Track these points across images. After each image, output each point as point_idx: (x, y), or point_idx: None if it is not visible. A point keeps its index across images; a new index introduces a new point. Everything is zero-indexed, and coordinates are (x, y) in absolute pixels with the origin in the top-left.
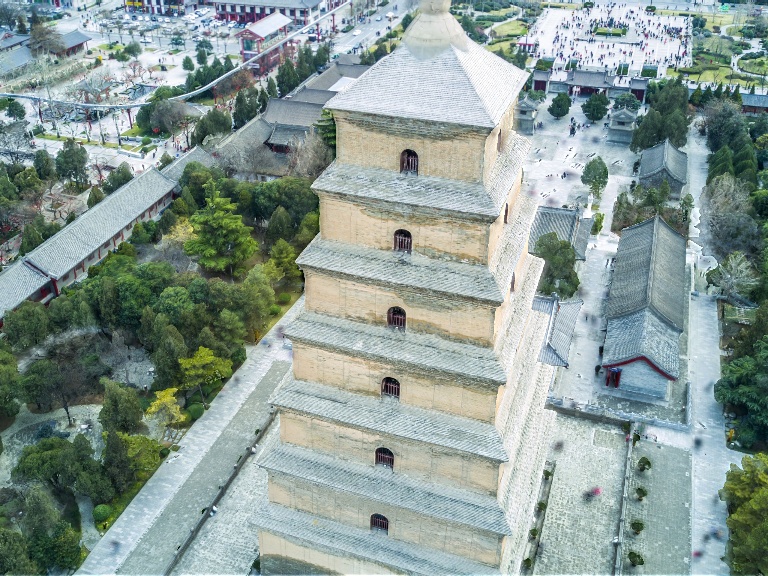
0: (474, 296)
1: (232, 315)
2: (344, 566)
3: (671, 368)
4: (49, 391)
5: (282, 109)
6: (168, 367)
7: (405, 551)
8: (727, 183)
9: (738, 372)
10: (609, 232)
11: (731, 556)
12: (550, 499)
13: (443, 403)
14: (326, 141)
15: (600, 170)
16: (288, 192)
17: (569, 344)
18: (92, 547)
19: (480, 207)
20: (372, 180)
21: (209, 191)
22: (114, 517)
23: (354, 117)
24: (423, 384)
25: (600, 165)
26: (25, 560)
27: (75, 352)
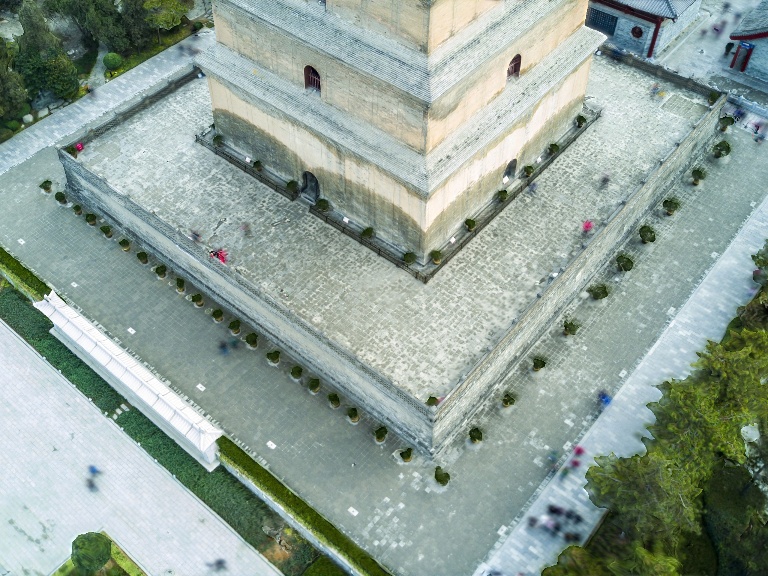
0: None
1: None
2: (281, 131)
3: None
4: None
5: None
6: None
7: (334, 118)
8: None
9: None
10: None
11: None
12: (571, 146)
13: None
14: None
15: None
16: None
17: None
18: (93, 89)
19: None
20: None
21: None
22: (125, 69)
23: None
24: None
25: None
26: None
27: None
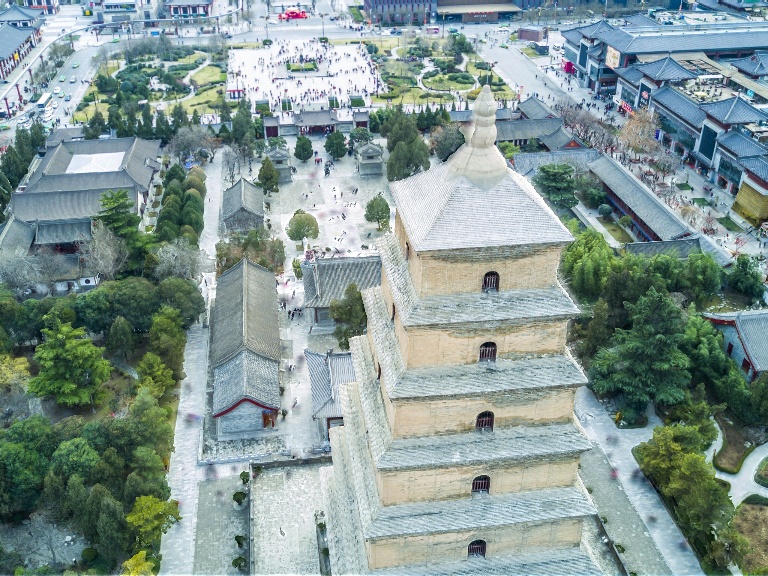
0: (563, 384)
1: (148, 451)
2: None
3: None
4: None
5: (31, 204)
6: (115, 531)
7: None
8: None
9: (604, 364)
10: None
11: (684, 519)
12: None
13: (530, 482)
14: (113, 232)
15: (381, 206)
16: (121, 299)
17: None
18: None
19: (564, 308)
20: (459, 305)
21: (50, 322)
22: None
23: (441, 253)
24: (513, 472)
25: (381, 202)
26: None
27: None
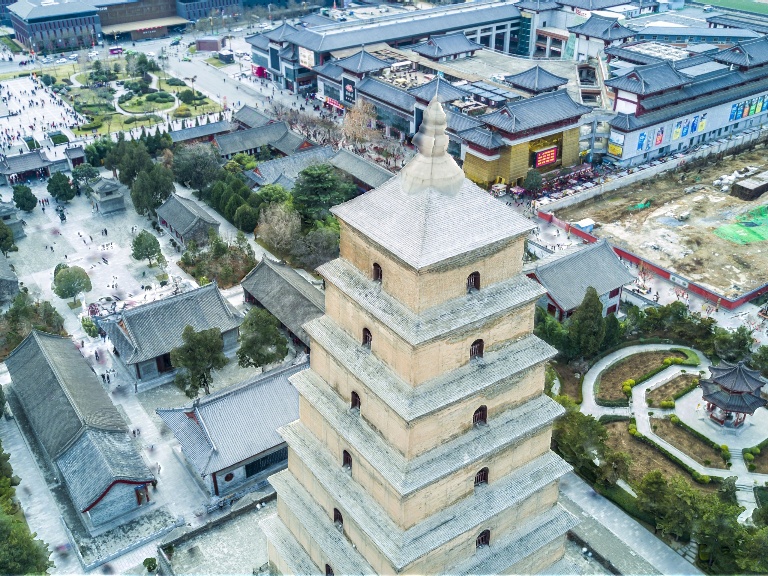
0: None
1: (36, 575)
2: None
3: None
4: None
5: None
6: None
7: None
8: (278, 210)
9: None
10: None
11: (570, 454)
12: None
13: (518, 460)
14: None
15: (149, 242)
16: None
17: None
18: None
19: (535, 291)
20: (453, 312)
21: None
22: None
23: (436, 265)
24: (505, 456)
25: (148, 237)
26: None
27: None
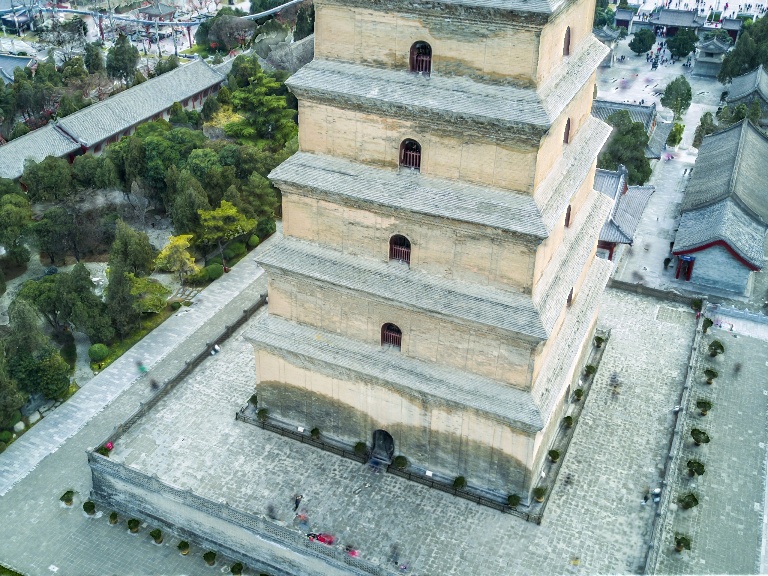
0: (514, 9)
1: (262, 179)
2: (349, 393)
3: (754, 257)
4: (60, 237)
5: None
6: (187, 219)
7: (419, 370)
8: None
9: None
10: (689, 146)
11: None
12: (601, 366)
13: (472, 170)
14: None
15: (683, 91)
16: None
17: (635, 225)
18: (83, 384)
19: None
20: None
21: (252, 66)
22: (112, 359)
23: None
24: (448, 145)
25: (683, 85)
26: None
27: (94, 208)
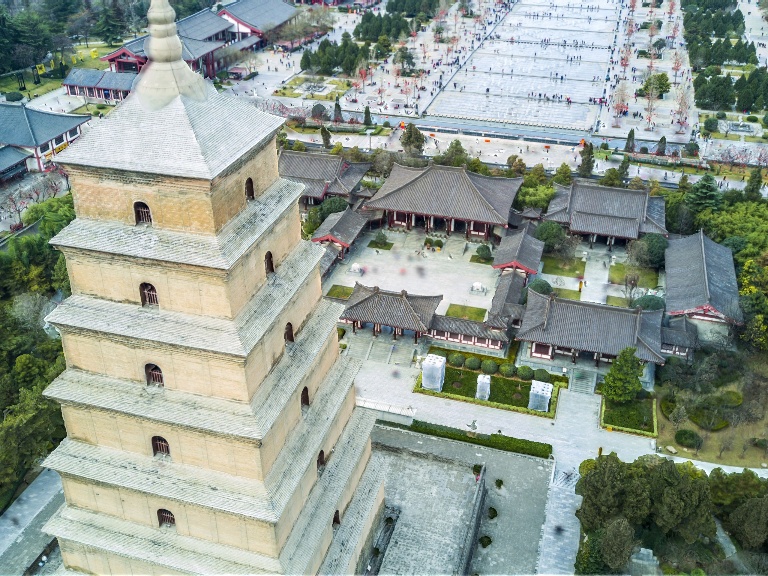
0: None
1: None
2: None
3: None
4: None
5: None
6: None
7: None
8: None
9: None
10: None
11: None
12: None
13: None
14: None
15: None
16: None
17: None
18: None
19: None
20: None
21: None
22: None
23: None
24: None
25: None
26: (593, 494)
27: None
